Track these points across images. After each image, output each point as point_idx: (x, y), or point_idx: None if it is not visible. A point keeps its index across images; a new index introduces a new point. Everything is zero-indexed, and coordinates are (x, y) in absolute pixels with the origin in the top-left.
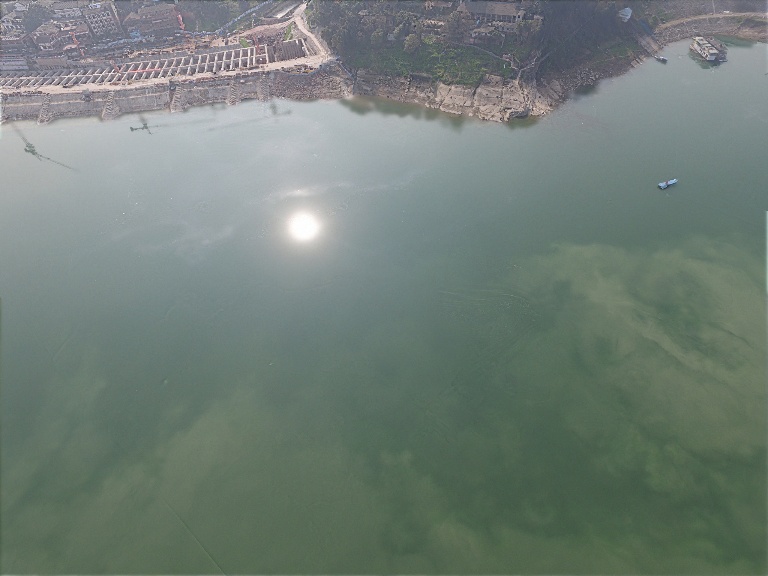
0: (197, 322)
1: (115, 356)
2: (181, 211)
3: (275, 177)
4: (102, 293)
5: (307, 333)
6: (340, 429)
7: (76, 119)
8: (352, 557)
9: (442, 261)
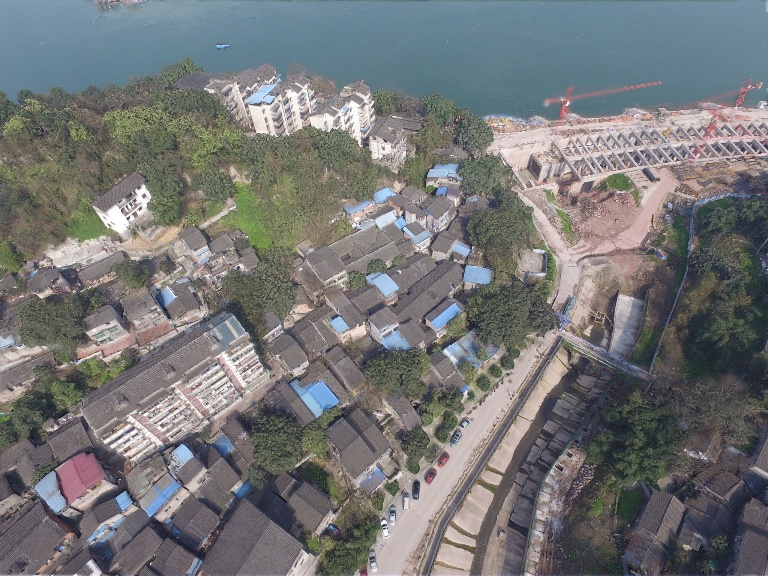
0: None
1: None
2: (543, 37)
3: (486, 55)
4: (555, 8)
5: None
6: None
7: (747, 106)
8: None
9: (375, 15)
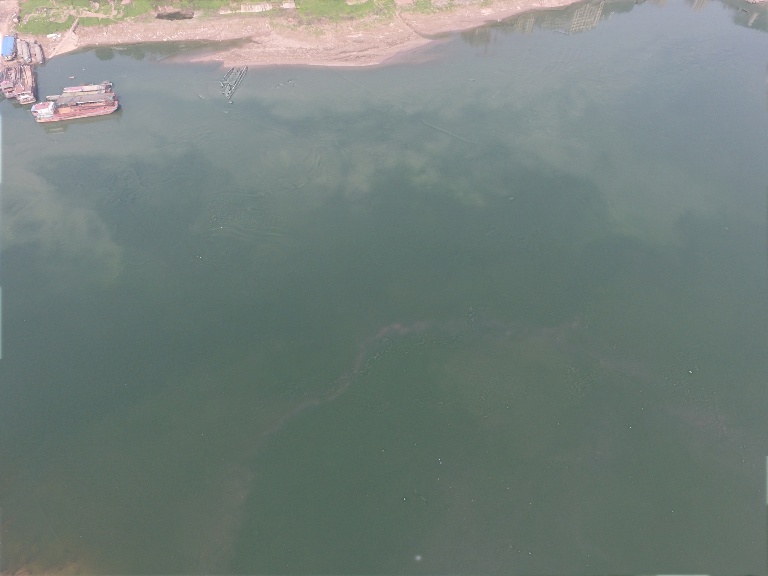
0: (504, 225)
1: (558, 199)
2: (606, 372)
3: (487, 440)
4: (620, 259)
5: (405, 217)
6: (379, 171)
7: None
8: (372, 128)
9: (270, 259)
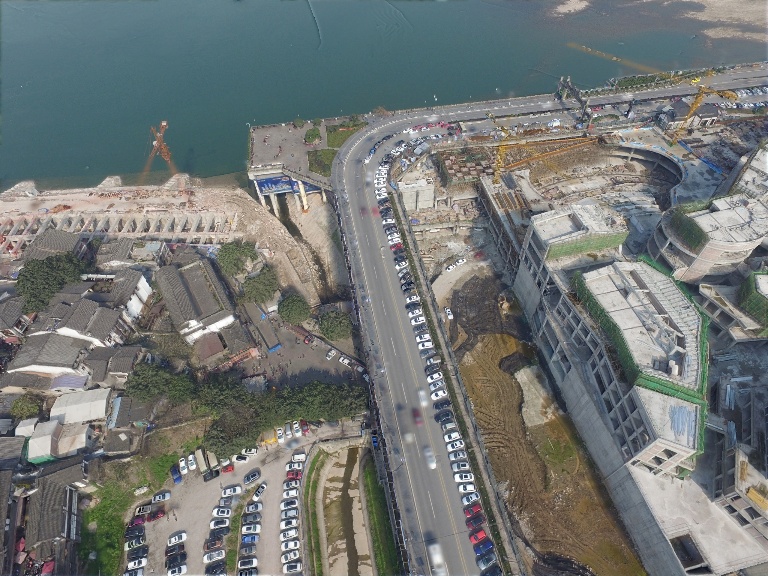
0: None
1: (32, 27)
2: None
3: None
4: (42, 50)
5: None
6: None
7: (70, 185)
8: None
9: None
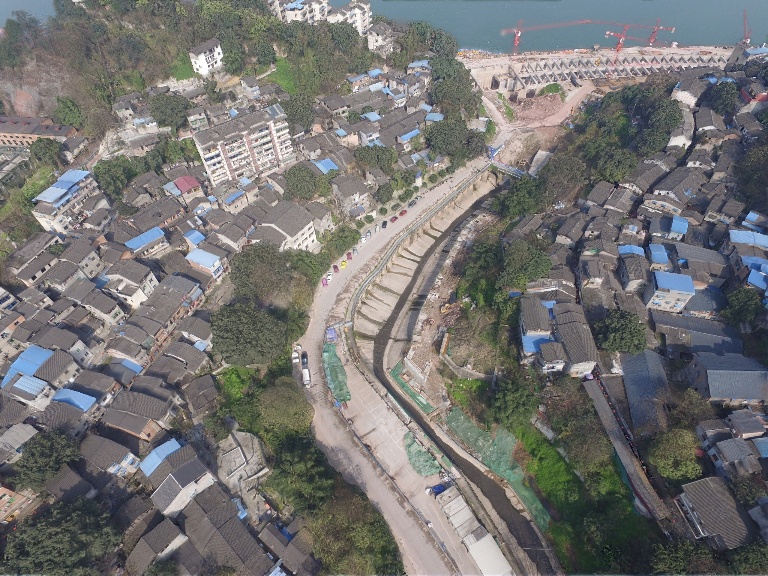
0: None
1: None
2: None
3: (470, 14)
4: None
5: None
6: None
7: None
8: None
9: None
